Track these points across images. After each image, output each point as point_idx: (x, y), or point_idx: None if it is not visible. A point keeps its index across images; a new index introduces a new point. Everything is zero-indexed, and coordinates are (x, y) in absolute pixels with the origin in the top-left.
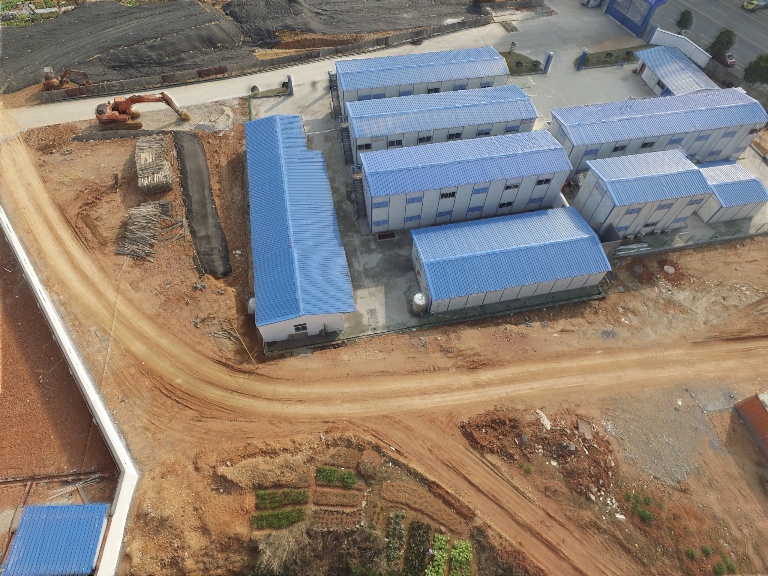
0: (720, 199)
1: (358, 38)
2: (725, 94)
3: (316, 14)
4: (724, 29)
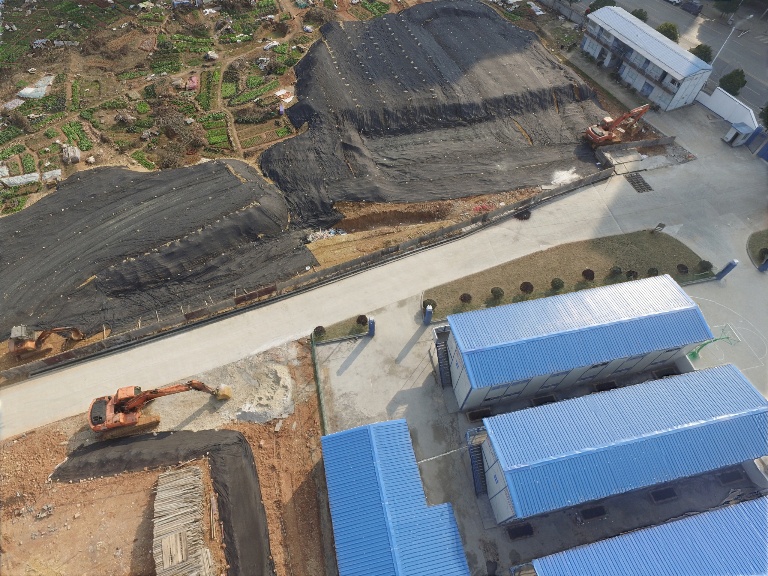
0: None
1: (442, 208)
2: None
3: (381, 166)
4: None
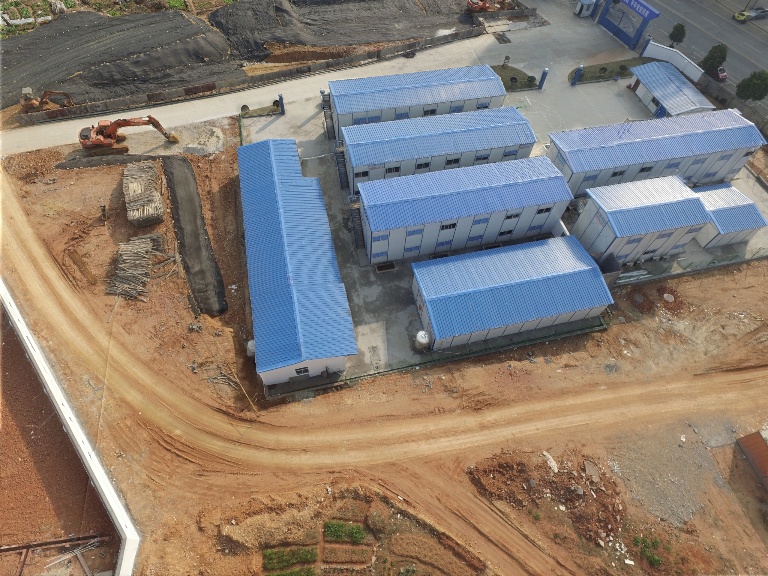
0: (718, 225)
1: (349, 50)
2: (720, 115)
3: (305, 24)
4: (714, 40)
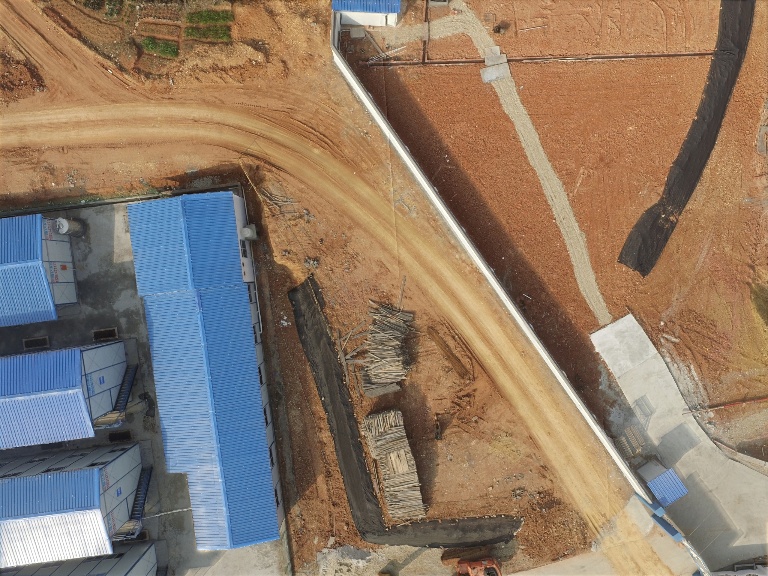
0: None
1: None
2: None
3: None
4: None
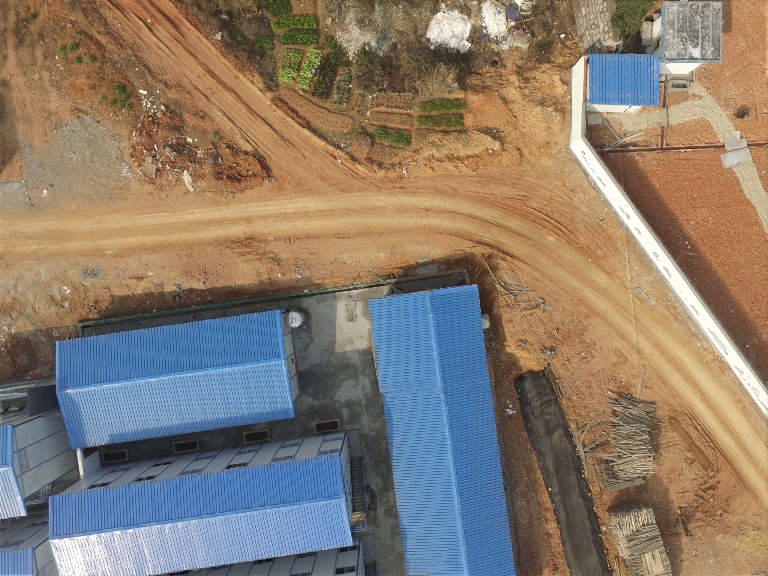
0: None
1: None
2: None
3: None
4: None
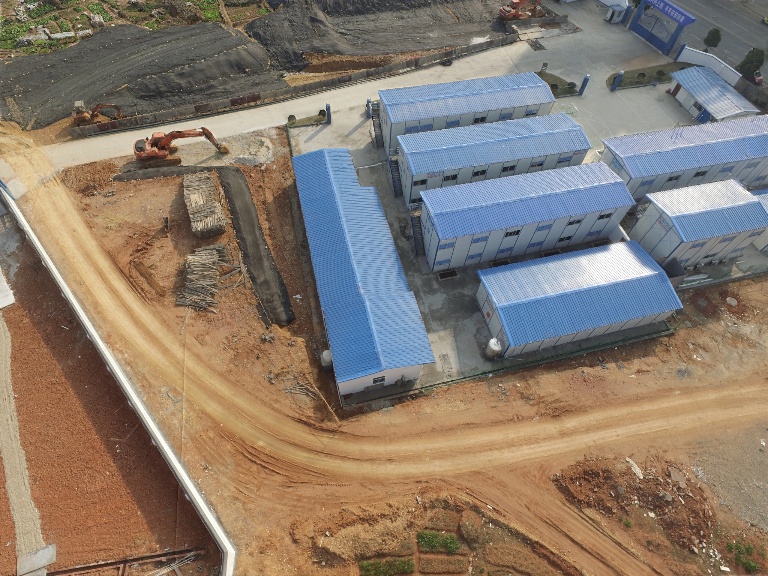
0: None
1: (386, 59)
2: None
3: (340, 34)
4: (746, 44)
